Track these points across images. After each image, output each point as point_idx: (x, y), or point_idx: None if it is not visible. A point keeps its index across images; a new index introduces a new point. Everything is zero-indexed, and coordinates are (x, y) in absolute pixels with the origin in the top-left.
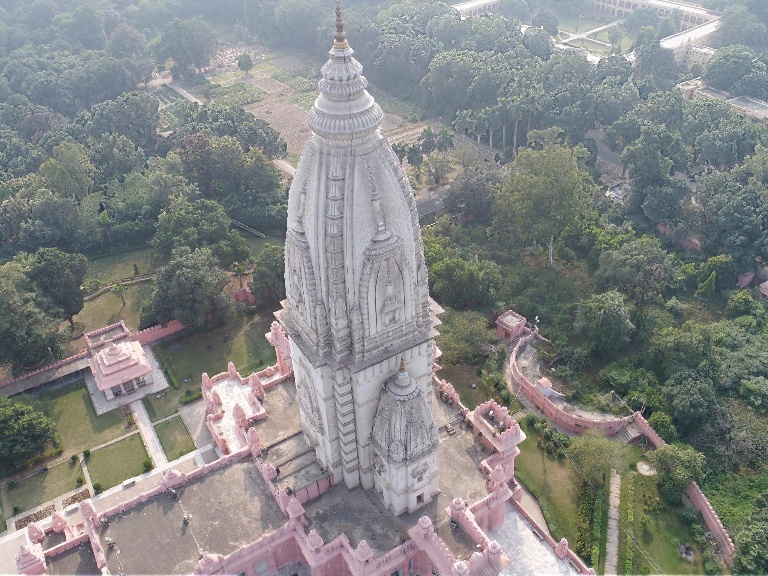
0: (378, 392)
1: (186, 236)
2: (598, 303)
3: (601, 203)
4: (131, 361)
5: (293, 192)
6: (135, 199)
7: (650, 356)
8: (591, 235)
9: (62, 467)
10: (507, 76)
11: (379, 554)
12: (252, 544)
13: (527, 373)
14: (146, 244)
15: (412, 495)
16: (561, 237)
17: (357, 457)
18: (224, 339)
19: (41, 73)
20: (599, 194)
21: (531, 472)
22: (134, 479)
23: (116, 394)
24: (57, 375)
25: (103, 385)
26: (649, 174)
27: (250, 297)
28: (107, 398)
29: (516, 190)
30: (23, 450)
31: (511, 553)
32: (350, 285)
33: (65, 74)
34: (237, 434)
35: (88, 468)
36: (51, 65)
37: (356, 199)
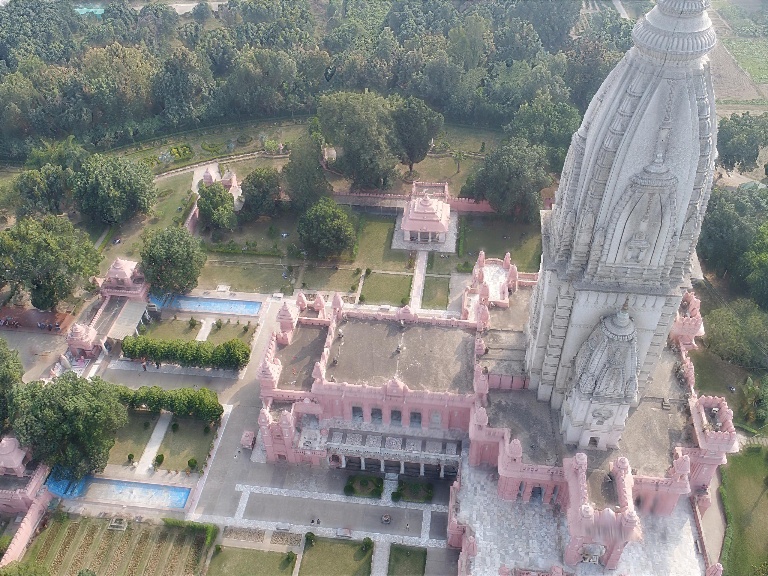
0: (596, 322)
1: (532, 131)
2: None
3: None
4: (435, 217)
5: (595, 97)
6: (511, 84)
7: None
8: None
9: (348, 272)
10: None
11: (529, 462)
12: (435, 393)
13: None
14: (503, 129)
15: (586, 433)
16: None
17: (555, 374)
18: (521, 235)
19: None
20: None
21: (739, 497)
22: (390, 307)
23: (413, 238)
24: (379, 204)
25: (405, 226)
26: None
27: None
28: (405, 238)
29: None
30: (327, 245)
31: (659, 544)
32: (605, 204)
33: None
34: (476, 308)
35: (364, 282)
36: None
37: (643, 121)
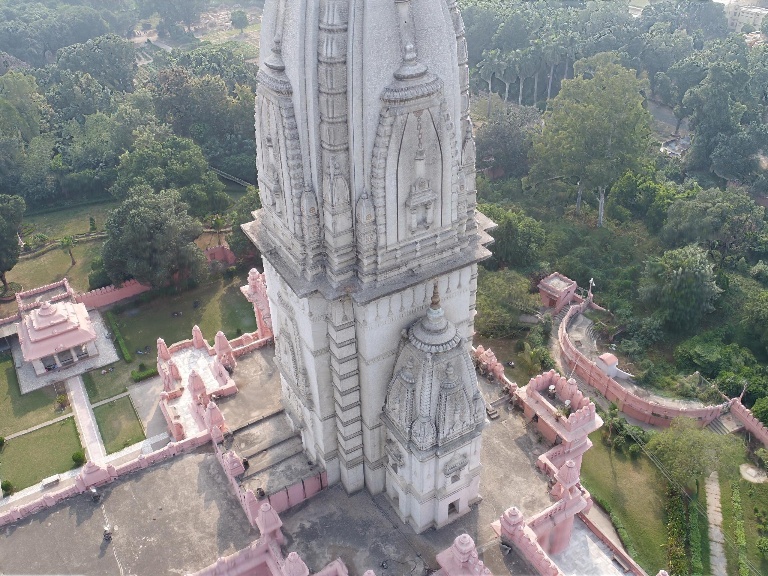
0: (396, 343)
1: (150, 177)
2: (674, 260)
3: (656, 158)
4: (69, 325)
5: (267, 5)
6: (95, 141)
7: (742, 329)
8: (649, 190)
9: None
10: (539, 19)
11: None
12: (201, 572)
13: (582, 348)
14: (108, 197)
15: (442, 502)
16: (611, 194)
17: (361, 445)
18: (194, 304)
19: (8, 23)
20: (652, 149)
21: (596, 476)
22: (58, 476)
23: (49, 368)
24: None
25: (30, 354)
26: (717, 121)
27: (229, 256)
28: (36, 372)
29: (561, 129)
30: None
31: None
32: (357, 155)
33: (34, 23)
34: (194, 414)
35: None
36: (21, 15)
37: None
